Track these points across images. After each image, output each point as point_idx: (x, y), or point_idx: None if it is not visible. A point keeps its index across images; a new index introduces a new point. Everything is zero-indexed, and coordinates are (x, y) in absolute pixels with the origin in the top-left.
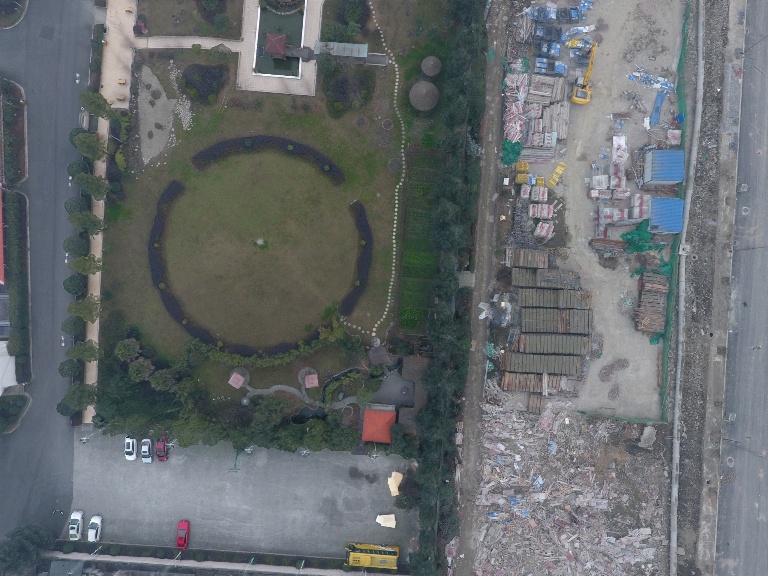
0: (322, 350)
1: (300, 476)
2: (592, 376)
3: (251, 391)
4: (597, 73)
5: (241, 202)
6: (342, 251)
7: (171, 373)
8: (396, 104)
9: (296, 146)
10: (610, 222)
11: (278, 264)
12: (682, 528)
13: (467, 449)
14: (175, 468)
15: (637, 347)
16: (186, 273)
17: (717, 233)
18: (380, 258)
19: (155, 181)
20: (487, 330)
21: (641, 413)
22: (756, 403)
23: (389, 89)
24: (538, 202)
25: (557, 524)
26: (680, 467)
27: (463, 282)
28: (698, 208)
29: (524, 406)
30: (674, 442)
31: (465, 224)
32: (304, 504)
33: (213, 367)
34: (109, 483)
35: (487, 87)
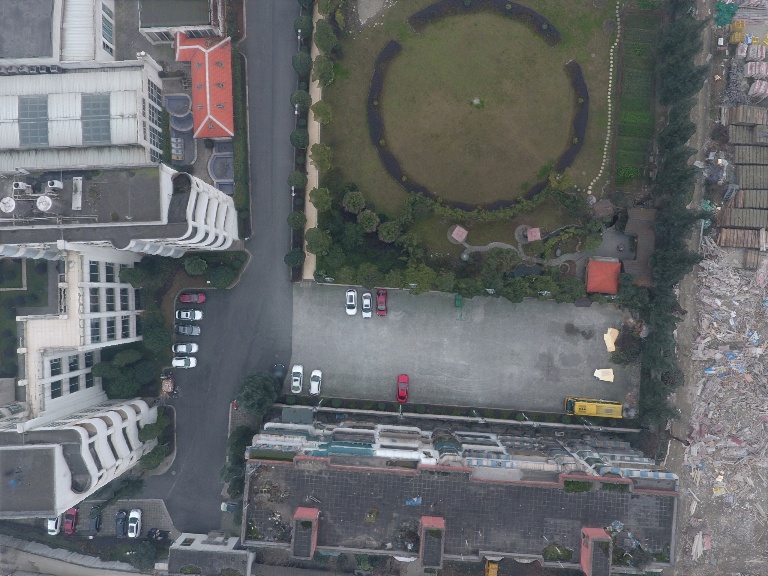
0: (538, 208)
1: (517, 332)
2: None
3: (468, 248)
4: None
5: (457, 62)
6: (558, 110)
7: (397, 225)
8: None
9: (514, 5)
10: None
11: (494, 123)
12: None
13: (683, 305)
14: (393, 324)
15: None
16: (403, 132)
17: None
18: (595, 117)
19: (372, 41)
20: (702, 188)
21: None
22: None
23: None
24: (754, 61)
25: None
26: None
27: None
28: None
29: (740, 263)
30: None
31: None
32: (521, 360)
33: (430, 224)
34: (328, 338)
35: None
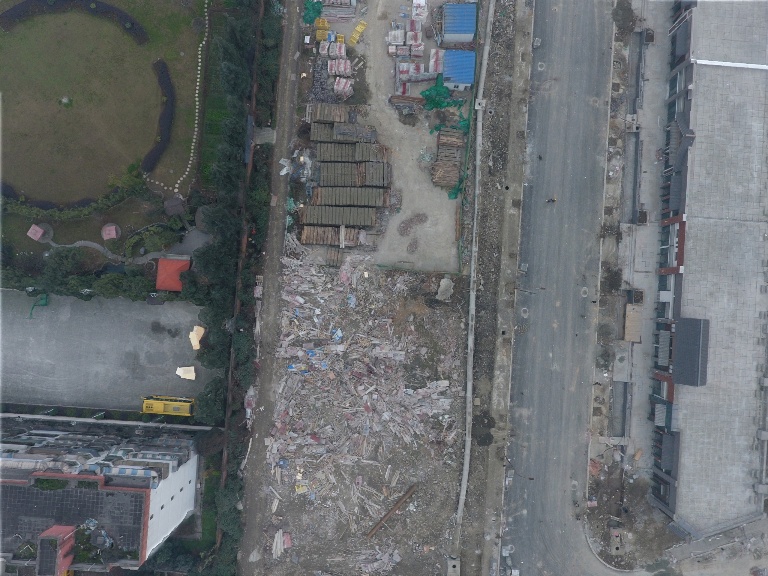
0: (125, 206)
1: (103, 330)
2: (391, 230)
3: None
4: None
5: (46, 61)
6: (146, 109)
7: None
8: None
9: (99, 4)
10: (407, 77)
11: (82, 122)
12: (478, 379)
13: (267, 303)
14: None
15: (436, 202)
16: None
17: (513, 88)
18: (183, 116)
19: None
20: (288, 186)
21: (439, 267)
22: (550, 255)
23: None
24: (337, 59)
25: (354, 375)
26: (477, 319)
27: (264, 138)
28: (496, 65)
29: (324, 260)
30: (470, 294)
31: (262, 79)
32: (107, 358)
33: (17, 223)
34: None
35: None
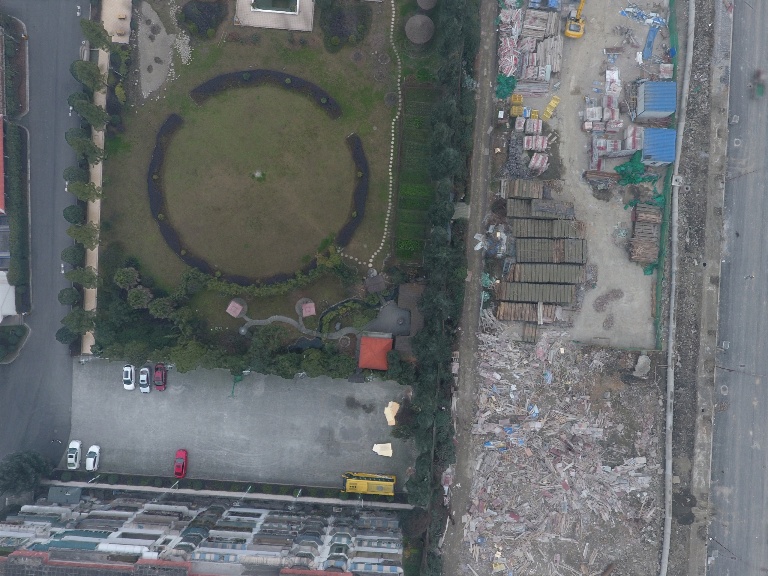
0: (319, 281)
1: (297, 406)
2: (587, 306)
3: (249, 321)
4: (590, 9)
5: (239, 135)
6: (339, 183)
7: (169, 301)
8: (392, 39)
9: (294, 80)
10: (604, 153)
11: (276, 196)
12: (677, 456)
13: (463, 379)
14: (173, 398)
15: (631, 277)
16: (185, 205)
17: (709, 164)
18: (377, 190)
19: (154, 115)
20: (483, 261)
21: (635, 343)
22: (749, 332)
23: (385, 25)
24: (532, 134)
25: (553, 453)
26: (675, 396)
27: (459, 214)
28: (690, 141)
29: (519, 336)
30: (668, 371)
31: (460, 155)
32: (301, 434)
33: (211, 298)
34: (107, 413)
35: (482, 23)
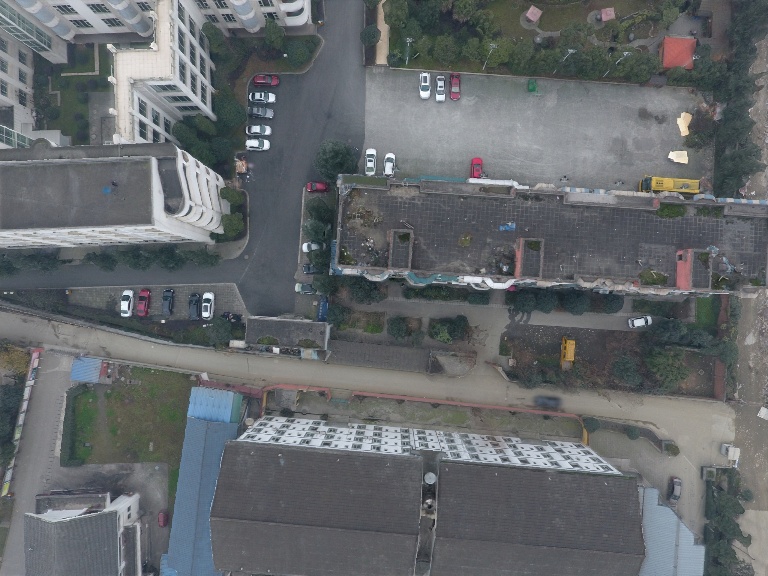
0: None
1: (590, 117)
2: None
3: (541, 33)
4: None
5: None
6: None
7: None
8: None
9: None
10: None
11: None
12: None
13: None
14: (466, 109)
15: None
16: None
17: None
18: None
19: None
20: None
21: None
22: None
23: None
24: None
25: None
26: None
27: None
28: None
29: None
30: None
31: None
32: (594, 144)
33: (503, 10)
34: (401, 123)
35: None
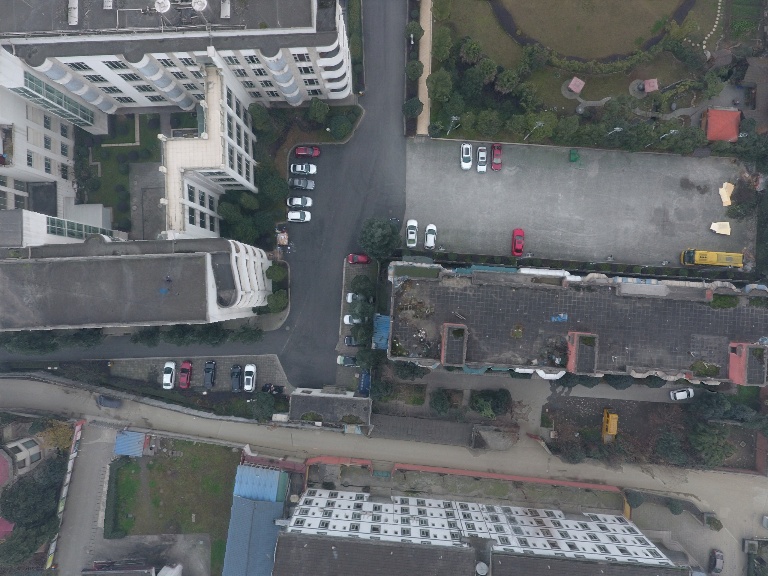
0: (652, 63)
1: (631, 187)
2: None
3: (582, 103)
4: None
5: None
6: None
7: None
8: None
9: None
10: None
11: None
12: None
13: None
14: (507, 179)
15: None
16: None
17: None
18: None
19: None
20: None
21: None
22: None
23: None
24: None
25: None
26: None
27: None
28: None
29: None
30: None
31: None
32: (636, 214)
33: (544, 79)
34: (441, 194)
35: None
